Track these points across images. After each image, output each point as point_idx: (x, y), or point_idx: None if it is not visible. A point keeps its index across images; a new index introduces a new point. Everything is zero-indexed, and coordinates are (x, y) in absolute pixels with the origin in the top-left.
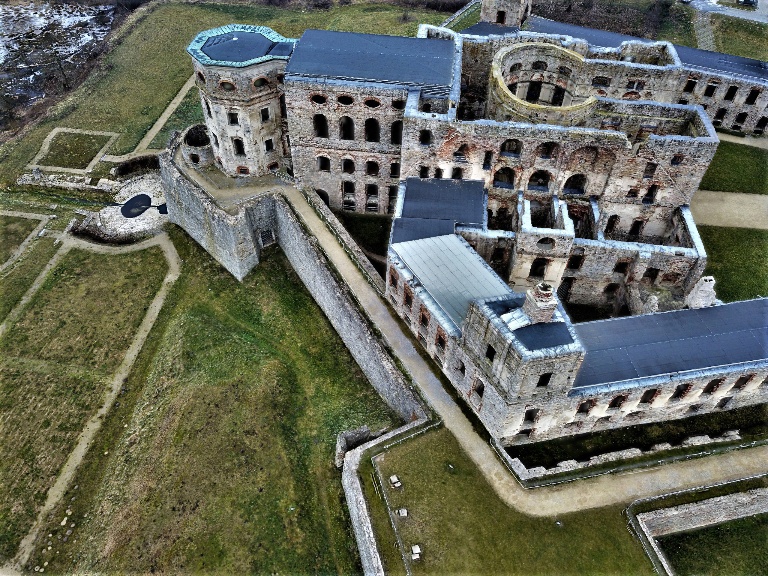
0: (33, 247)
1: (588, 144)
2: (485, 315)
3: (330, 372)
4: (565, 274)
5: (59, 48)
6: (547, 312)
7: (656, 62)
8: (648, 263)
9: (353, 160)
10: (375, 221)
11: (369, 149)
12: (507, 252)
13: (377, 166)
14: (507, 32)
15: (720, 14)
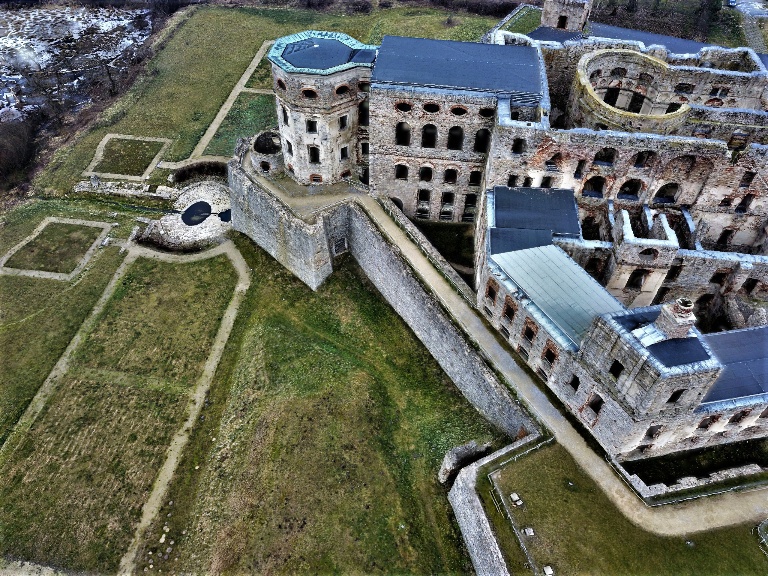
0: (99, 256)
1: (687, 153)
2: (614, 330)
3: (420, 384)
4: None
5: (100, 53)
6: (684, 328)
7: (736, 68)
8: (749, 274)
9: (432, 168)
10: (449, 229)
11: (450, 157)
12: (602, 262)
13: (455, 174)
14: (570, 37)
15: (767, 18)
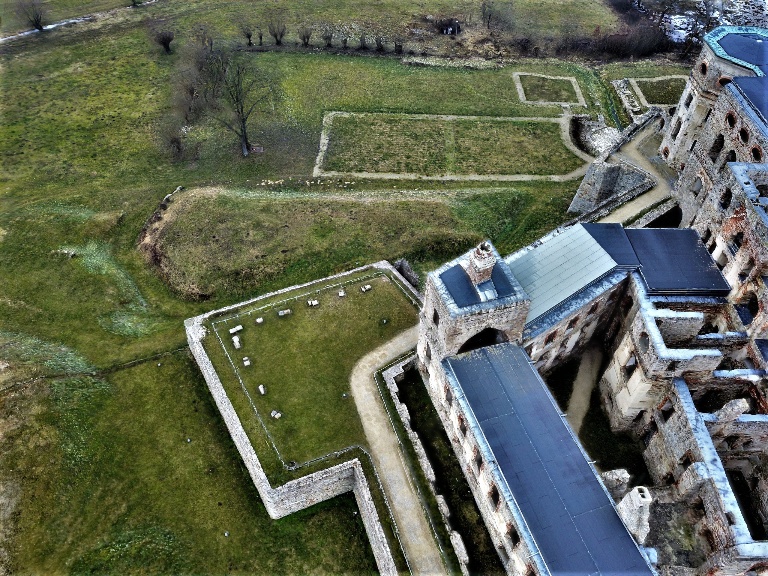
0: (549, 107)
1: None
2: None
3: None
4: (655, 414)
5: None
6: None
7: None
8: (694, 480)
9: None
10: None
11: None
12: None
13: None
14: None
15: None
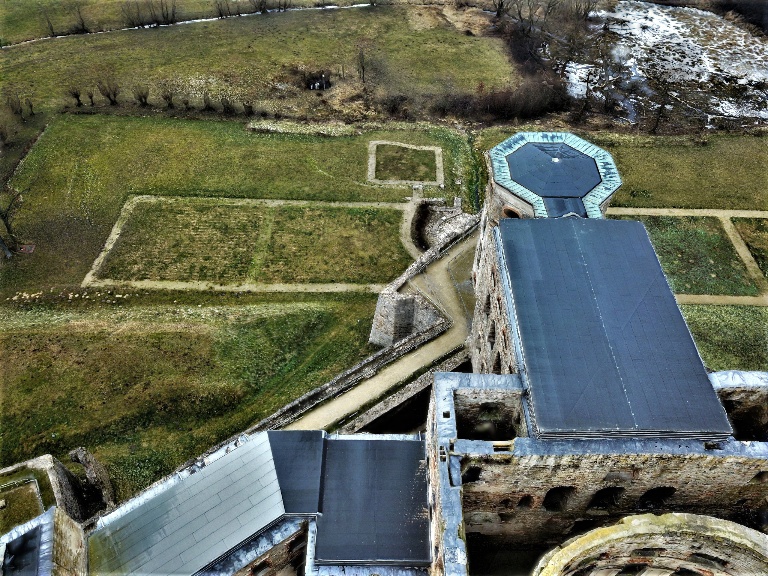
0: (399, 187)
1: None
2: None
3: None
4: None
5: (727, 104)
6: None
7: None
8: None
9: None
10: None
11: None
12: None
13: None
14: None
15: None
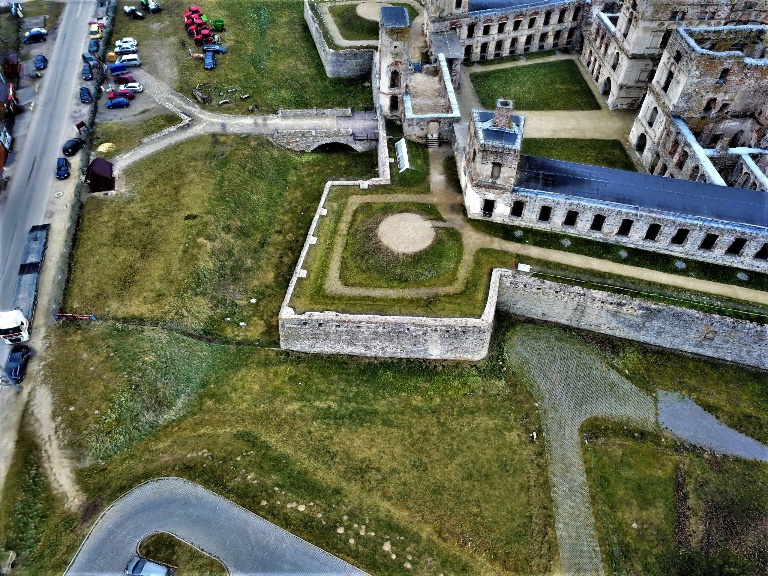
0: None
1: None
2: None
3: None
4: None
5: None
6: None
7: None
8: None
9: None
10: None
11: None
12: None
13: None
14: None
15: None
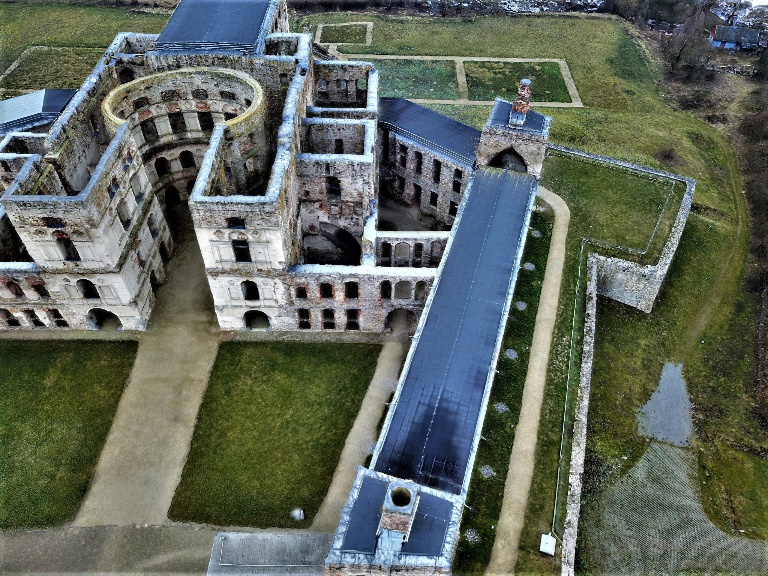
0: None
1: None
2: None
3: None
4: None
5: (513, 3)
6: None
7: None
8: None
9: None
10: None
11: None
12: None
13: None
14: (453, 149)
15: None
